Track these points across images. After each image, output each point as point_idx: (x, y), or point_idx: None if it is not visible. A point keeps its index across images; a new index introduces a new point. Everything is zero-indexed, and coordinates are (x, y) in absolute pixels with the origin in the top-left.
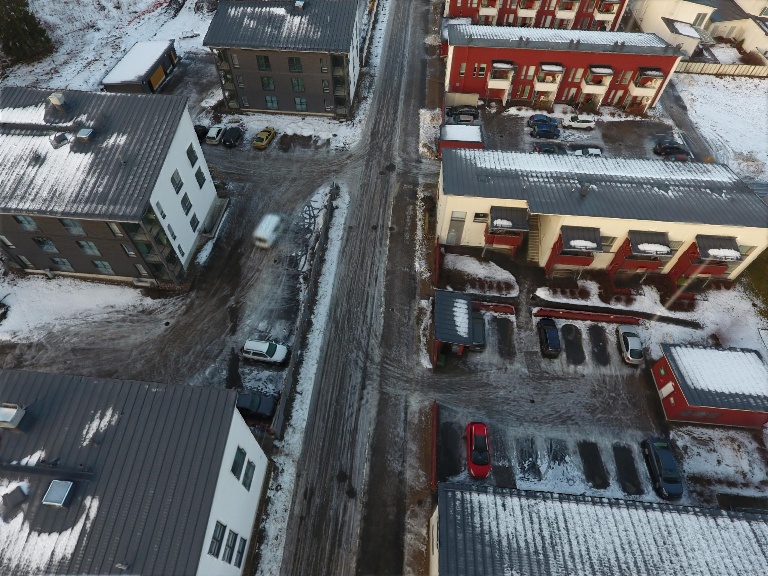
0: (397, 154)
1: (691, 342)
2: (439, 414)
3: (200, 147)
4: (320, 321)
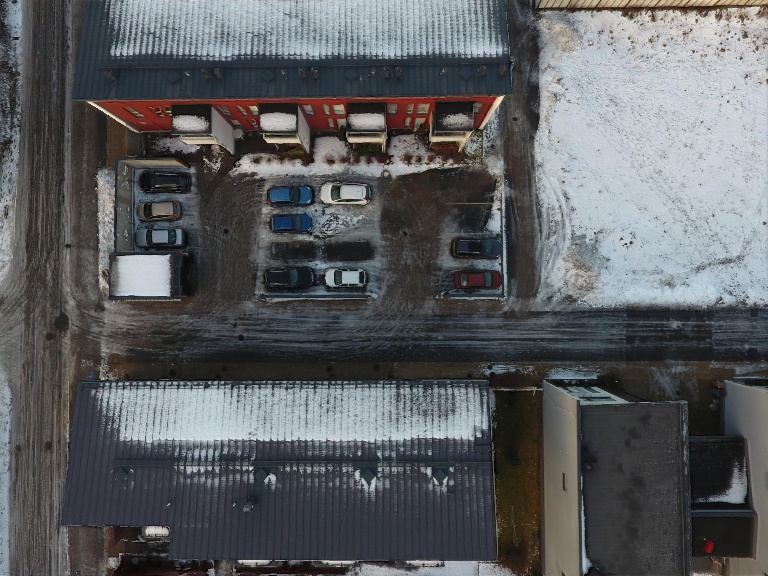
0: (68, 291)
1: None
2: None
3: None
4: None
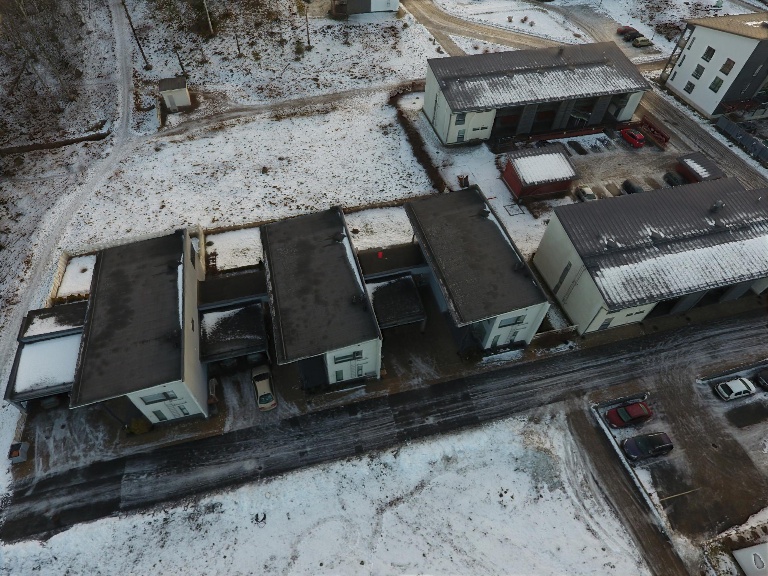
0: None
1: (549, 211)
2: (659, 148)
3: None
4: (763, 171)
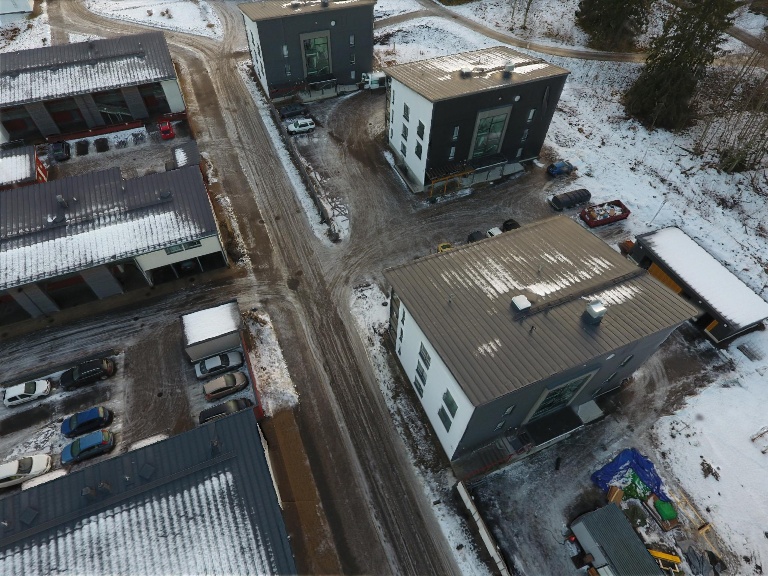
0: (295, 304)
1: None
2: (191, 138)
3: (429, 143)
4: (282, 152)
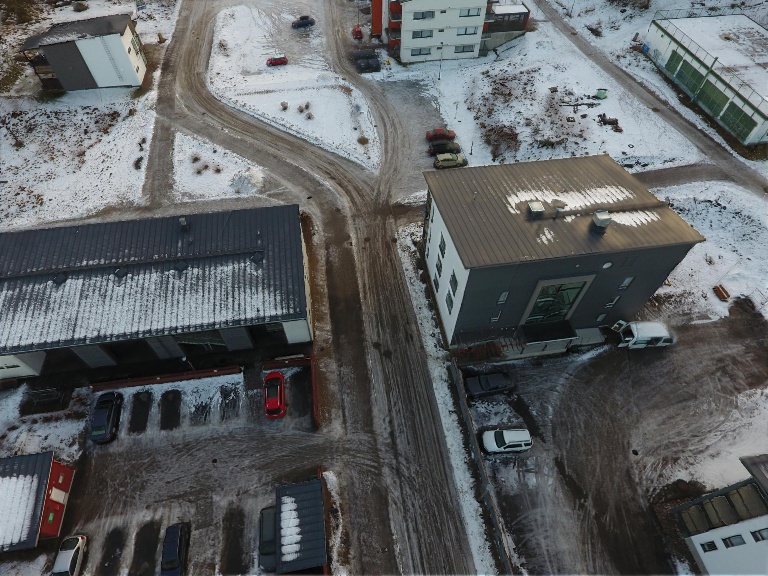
0: None
1: None
2: (312, 422)
3: None
4: (469, 506)
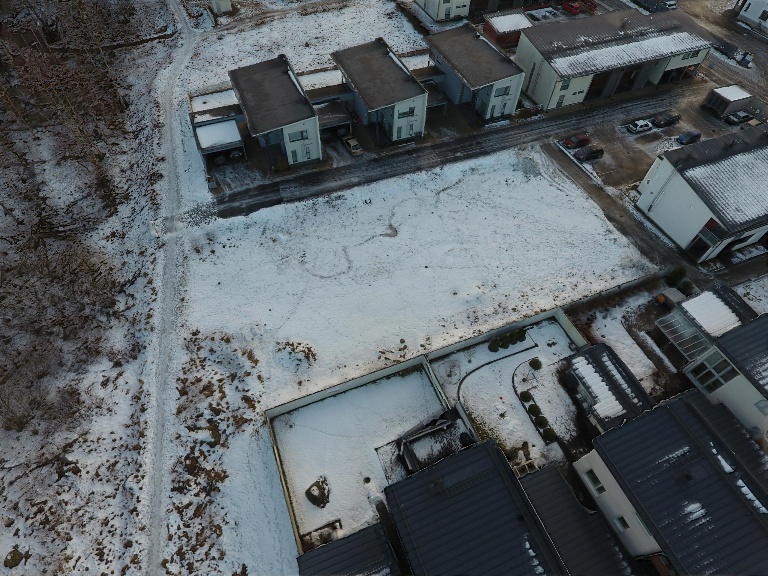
0: None
1: None
2: (590, 14)
3: None
4: None
